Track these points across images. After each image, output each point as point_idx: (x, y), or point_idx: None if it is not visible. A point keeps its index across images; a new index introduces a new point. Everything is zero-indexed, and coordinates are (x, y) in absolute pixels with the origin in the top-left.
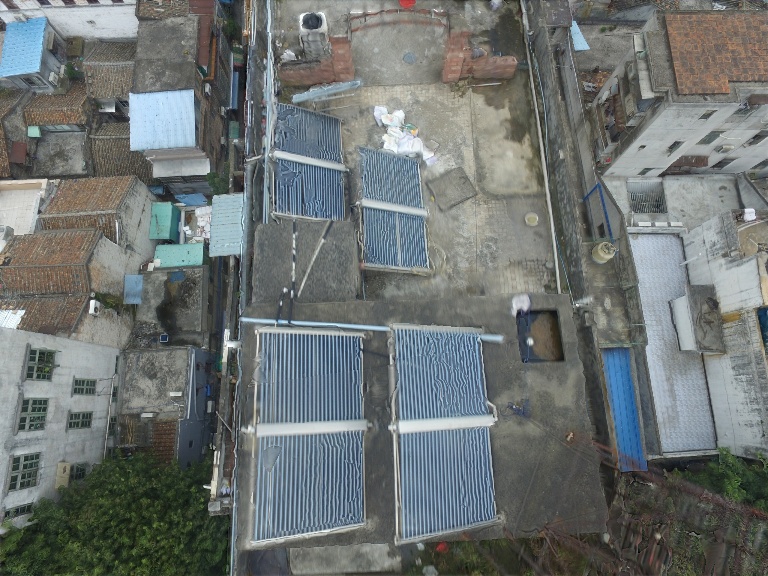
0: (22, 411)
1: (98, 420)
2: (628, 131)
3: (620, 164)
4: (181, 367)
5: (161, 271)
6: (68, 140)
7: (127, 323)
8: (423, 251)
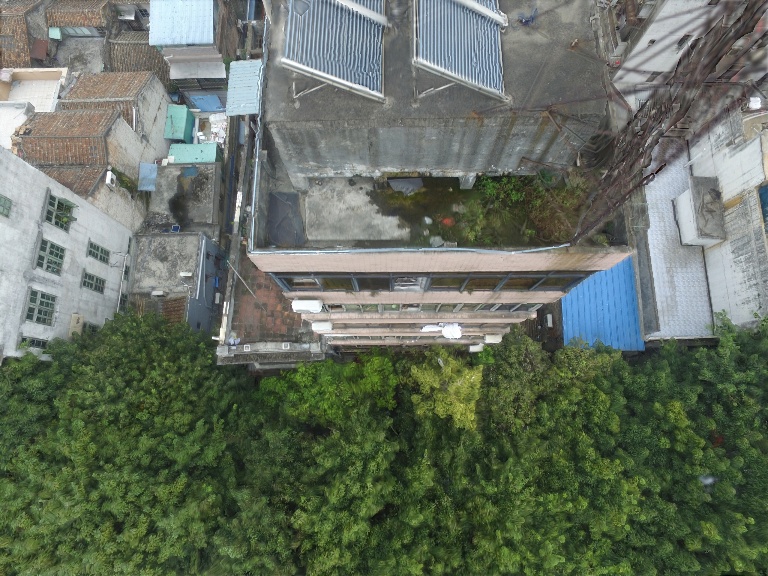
0: (41, 249)
1: (110, 291)
2: (638, 27)
3: (629, 66)
4: (192, 252)
5: (175, 166)
6: (87, 45)
7: (140, 210)
8: None
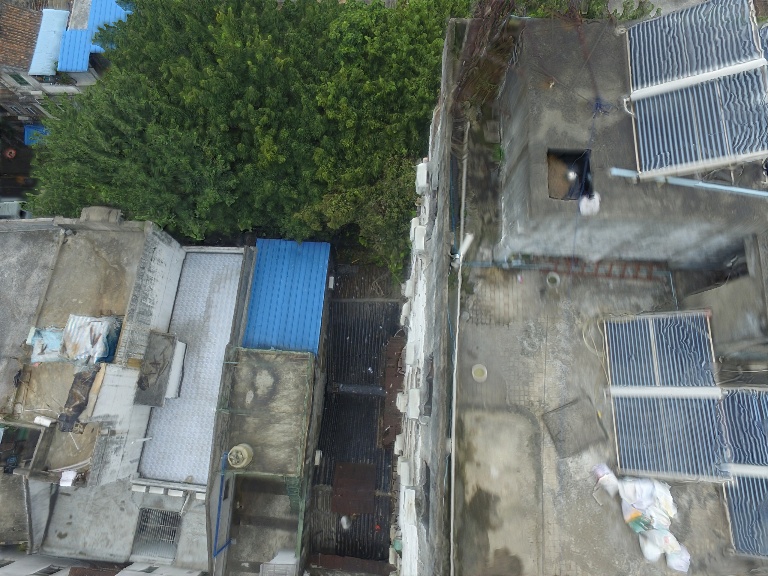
0: None
1: None
2: None
3: None
4: None
5: None
6: None
7: None
8: (614, 344)
